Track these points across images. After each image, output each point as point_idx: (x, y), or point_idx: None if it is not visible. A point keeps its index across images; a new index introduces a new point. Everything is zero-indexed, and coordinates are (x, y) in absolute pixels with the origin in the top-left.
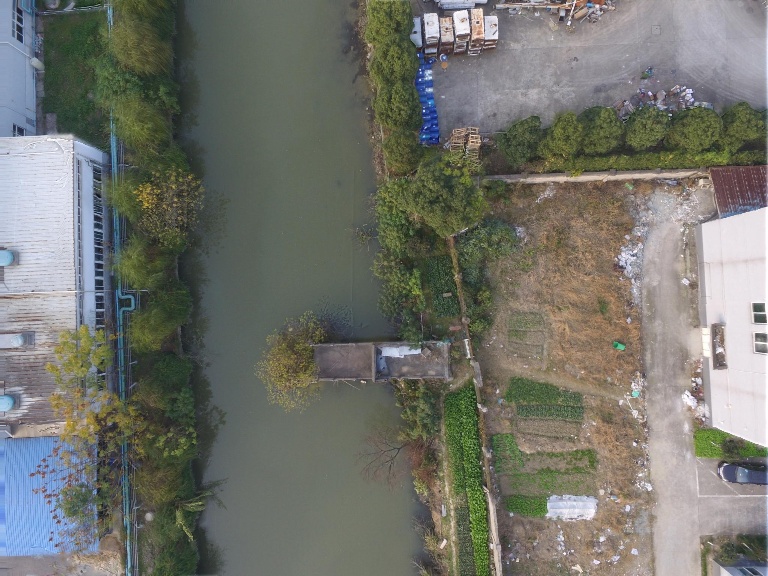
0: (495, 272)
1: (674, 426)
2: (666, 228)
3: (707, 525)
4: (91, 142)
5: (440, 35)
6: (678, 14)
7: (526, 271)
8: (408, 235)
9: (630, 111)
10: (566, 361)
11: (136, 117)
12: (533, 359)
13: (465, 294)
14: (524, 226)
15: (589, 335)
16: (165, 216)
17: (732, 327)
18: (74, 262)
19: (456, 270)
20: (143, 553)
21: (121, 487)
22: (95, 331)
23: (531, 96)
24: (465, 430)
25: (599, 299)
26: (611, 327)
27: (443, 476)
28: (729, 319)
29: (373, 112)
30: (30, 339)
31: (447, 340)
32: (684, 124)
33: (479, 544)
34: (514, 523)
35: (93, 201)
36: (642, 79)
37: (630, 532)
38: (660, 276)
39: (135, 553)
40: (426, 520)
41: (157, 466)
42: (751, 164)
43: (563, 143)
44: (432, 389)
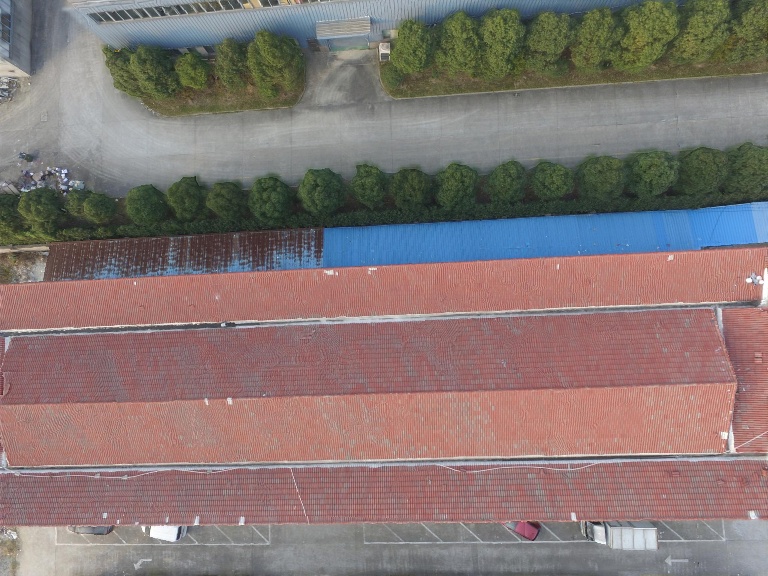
0: None
1: None
2: None
3: (62, 571)
4: None
5: None
6: (64, 102)
7: None
8: None
9: (6, 192)
10: None
11: None
12: None
13: None
14: None
15: None
16: None
17: None
18: None
19: None
20: None
21: None
22: None
23: None
24: None
25: None
26: None
27: None
28: None
29: None
30: None
31: None
32: None
33: None
34: None
35: None
36: (28, 161)
37: None
38: None
39: None
40: None
41: None
42: (85, 239)
43: None
44: None
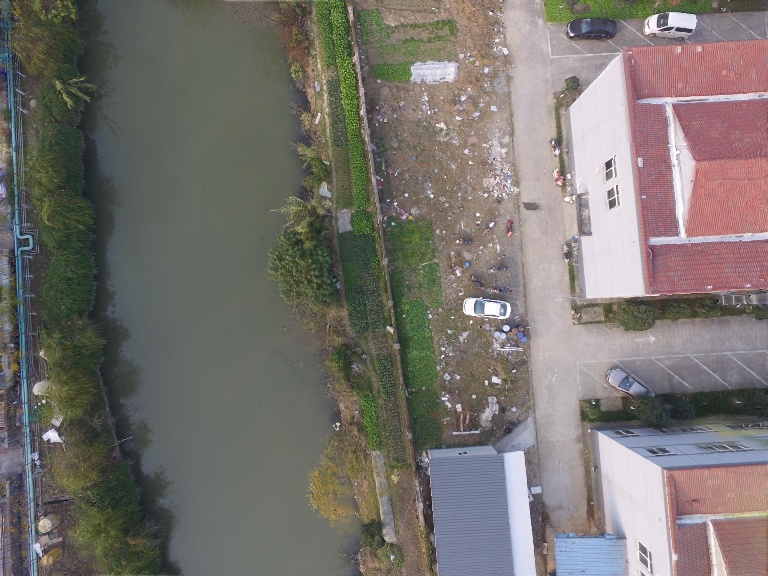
0: None
1: None
2: None
3: (559, 82)
4: None
5: None
6: None
7: None
8: None
9: None
10: None
11: None
12: None
13: None
14: None
15: None
16: None
17: None
18: None
19: None
20: (28, 136)
21: (5, 73)
22: None
23: None
24: (333, 6)
25: None
26: None
27: (315, 54)
28: None
29: None
30: None
31: None
32: None
33: (350, 110)
34: (381, 87)
35: None
36: None
37: (489, 91)
38: None
39: (20, 134)
40: (303, 105)
41: (34, 25)
42: None
43: None
44: None
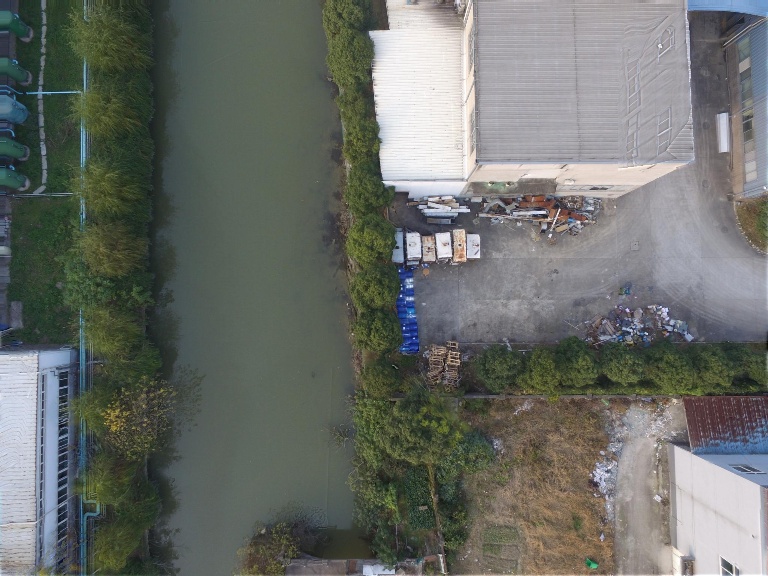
0: (471, 485)
1: None
2: (640, 443)
3: None
4: (58, 339)
5: (422, 255)
6: (656, 230)
7: (502, 484)
8: (385, 452)
9: (608, 330)
10: None
11: (106, 330)
12: (507, 574)
13: (441, 518)
14: (501, 439)
15: (563, 551)
16: (134, 435)
17: (701, 566)
18: (35, 491)
19: (432, 490)
20: None
21: None
22: (56, 548)
23: (511, 307)
24: None
25: (573, 515)
26: (584, 544)
27: None
28: (698, 556)
29: (353, 315)
30: None
31: (422, 559)
32: (659, 367)
33: None
34: None
35: (58, 411)
36: (620, 295)
37: None
38: (633, 492)
39: None
40: None
41: None
42: (722, 394)
43: (541, 387)
44: None
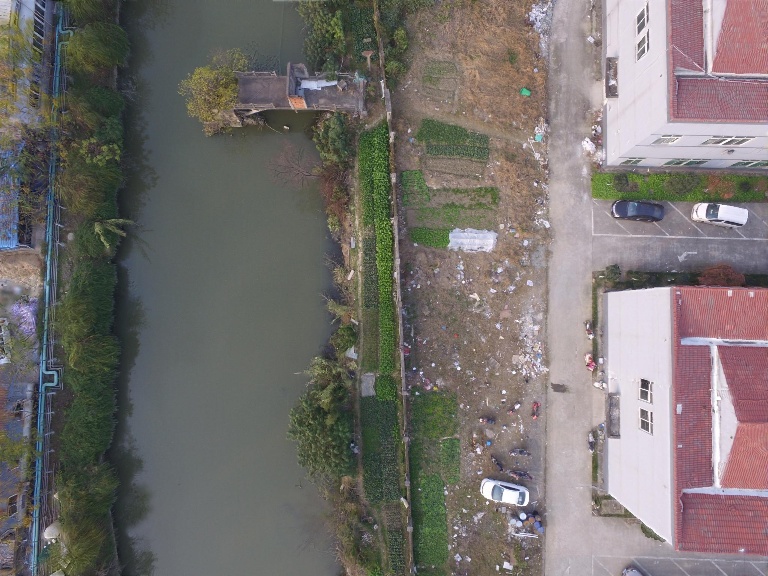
0: (414, 23)
1: (573, 170)
2: None
3: (600, 261)
4: None
5: None
6: None
7: (443, 23)
8: None
9: None
10: (475, 105)
11: None
12: (444, 103)
13: (380, 28)
14: None
15: (498, 82)
16: None
17: (623, 55)
18: None
19: None
20: (63, 270)
21: (46, 205)
22: (31, 49)
23: None
24: (376, 164)
25: (509, 51)
26: (518, 75)
27: (354, 210)
28: (621, 50)
29: None
30: None
31: (363, 76)
32: None
33: (383, 271)
34: (417, 252)
35: None
36: None
37: (527, 265)
38: (567, 34)
39: (55, 268)
40: (337, 257)
41: (78, 169)
42: None
43: None
44: (349, 129)
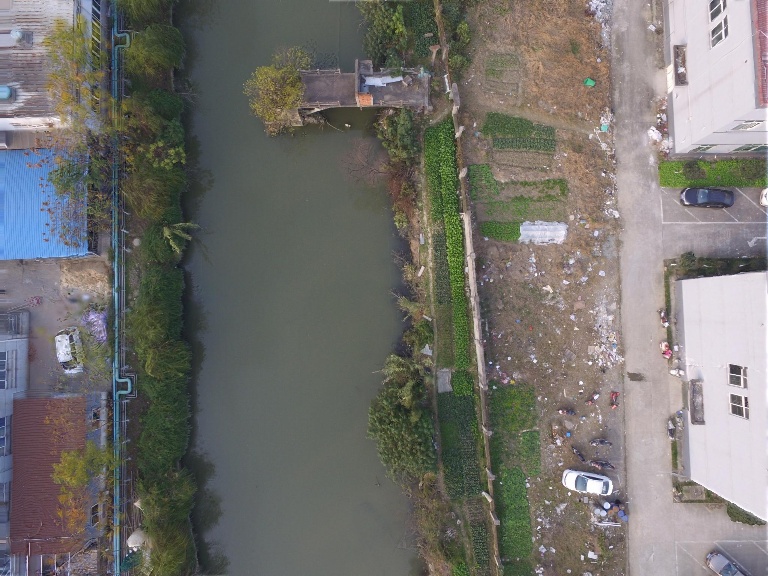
0: (474, 16)
1: (640, 159)
2: None
3: (670, 250)
4: None
5: None
6: None
7: (503, 16)
8: None
9: None
10: (540, 97)
11: None
12: (509, 96)
13: (445, 22)
14: None
15: (561, 73)
16: None
17: (692, 43)
18: None
19: (437, 3)
20: (130, 276)
21: (111, 211)
22: (91, 53)
23: None
24: (443, 159)
25: (571, 41)
26: (582, 66)
27: (422, 206)
28: (690, 38)
29: None
30: (28, 38)
31: (427, 71)
32: None
33: (455, 267)
34: (488, 246)
35: None
36: None
37: (598, 255)
38: (628, 23)
39: (122, 274)
40: (405, 254)
41: (147, 174)
42: None
43: None
44: (413, 125)
